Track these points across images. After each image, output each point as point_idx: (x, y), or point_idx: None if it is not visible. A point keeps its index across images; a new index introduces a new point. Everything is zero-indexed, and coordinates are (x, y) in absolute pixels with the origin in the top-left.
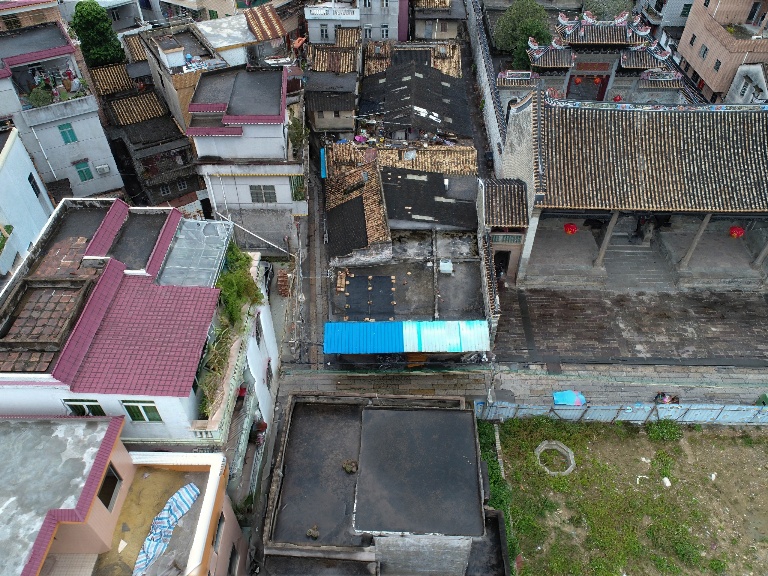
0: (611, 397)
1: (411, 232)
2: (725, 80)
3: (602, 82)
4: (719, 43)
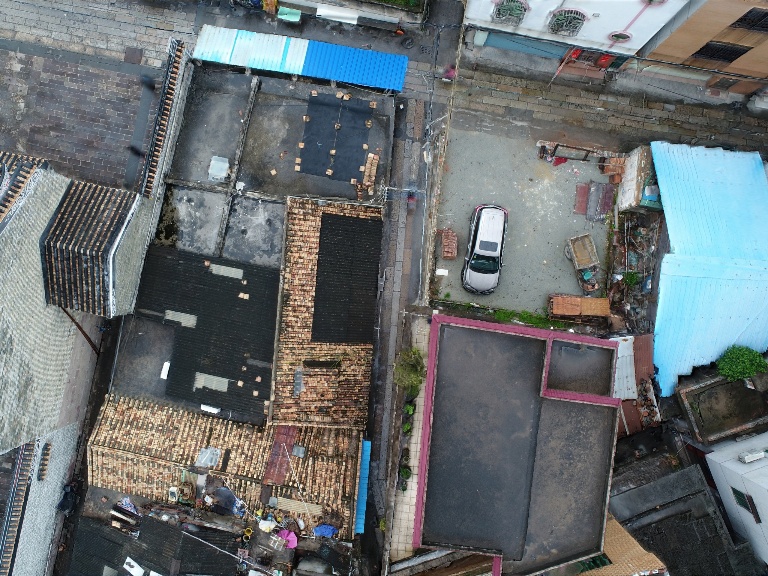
0: (84, 6)
1: (251, 262)
2: None
3: None
4: None
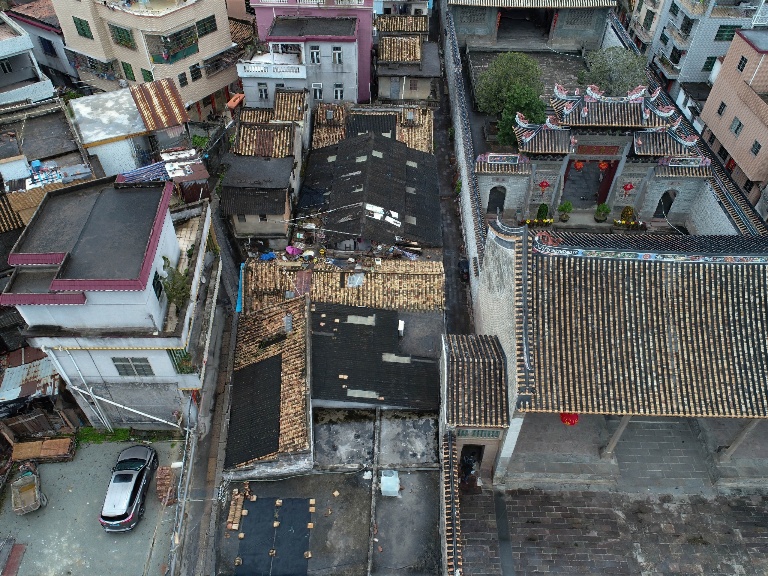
0: None
1: (346, 413)
2: (766, 167)
3: (609, 166)
4: (758, 120)
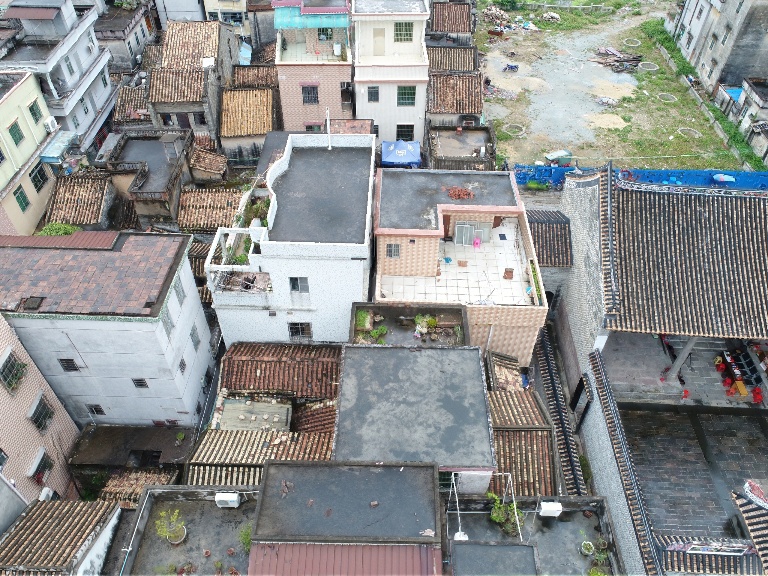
0: None
1: None
2: None
3: None
4: None
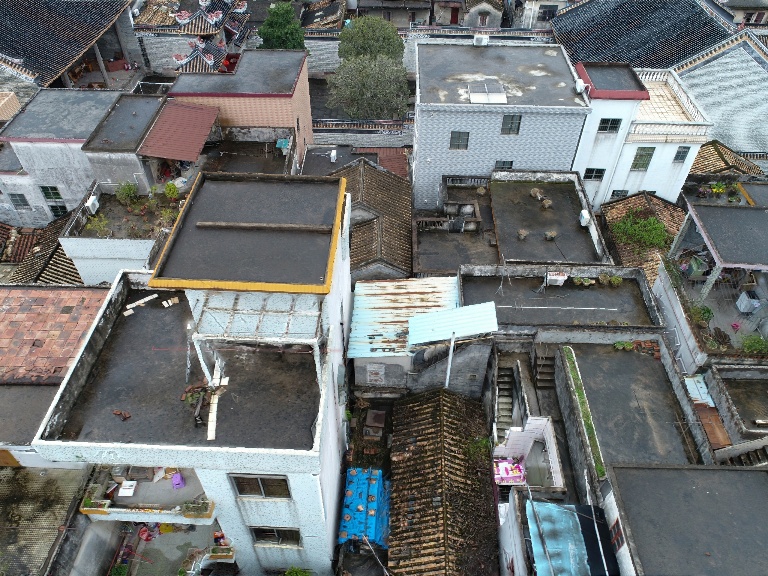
0: None
1: None
2: None
3: None
4: None
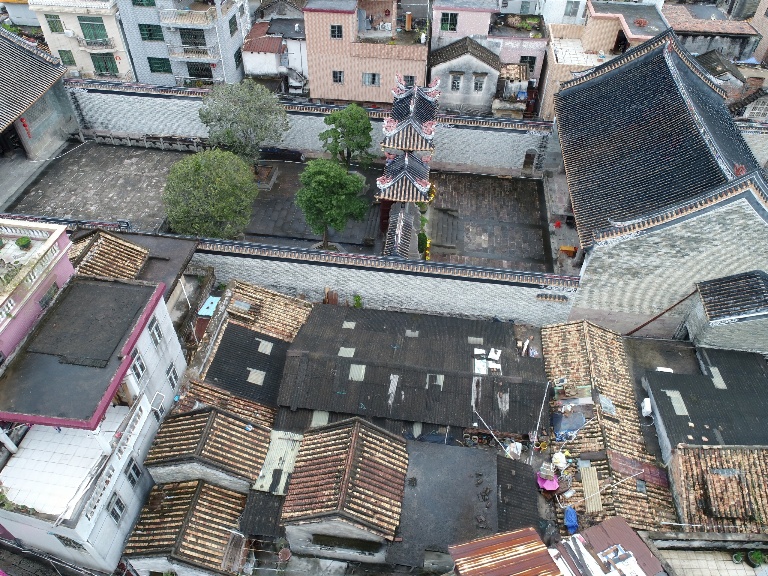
0: None
1: None
2: None
3: None
4: (397, 61)
